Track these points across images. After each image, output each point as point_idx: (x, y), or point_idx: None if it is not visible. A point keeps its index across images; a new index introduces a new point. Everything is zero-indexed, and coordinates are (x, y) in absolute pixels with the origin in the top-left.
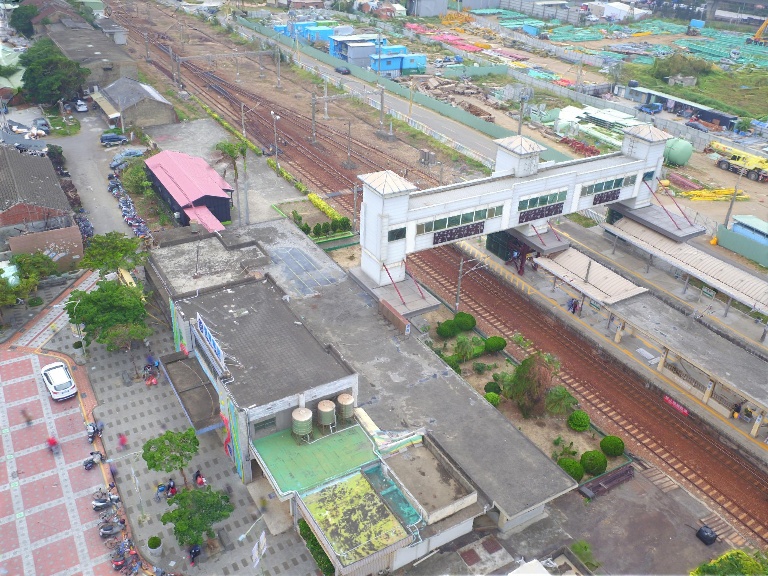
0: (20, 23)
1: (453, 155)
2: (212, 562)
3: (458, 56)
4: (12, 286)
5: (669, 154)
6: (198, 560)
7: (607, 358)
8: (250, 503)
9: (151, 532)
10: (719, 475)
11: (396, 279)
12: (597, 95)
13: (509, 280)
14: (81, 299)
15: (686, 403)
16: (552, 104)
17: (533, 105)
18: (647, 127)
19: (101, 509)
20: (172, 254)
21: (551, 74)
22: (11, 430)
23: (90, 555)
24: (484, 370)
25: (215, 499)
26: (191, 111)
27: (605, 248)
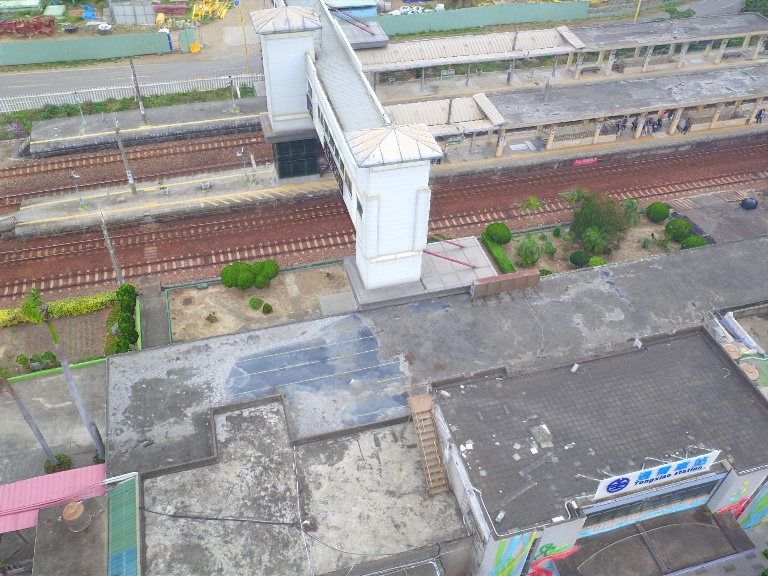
0: None
1: None
2: None
3: None
4: None
5: None
6: None
7: (509, 173)
8: None
9: None
10: (671, 175)
11: None
12: None
13: None
14: None
15: (595, 153)
16: None
17: None
18: None
19: None
20: (189, 571)
21: None
22: None
23: None
24: None
25: None
26: None
27: None
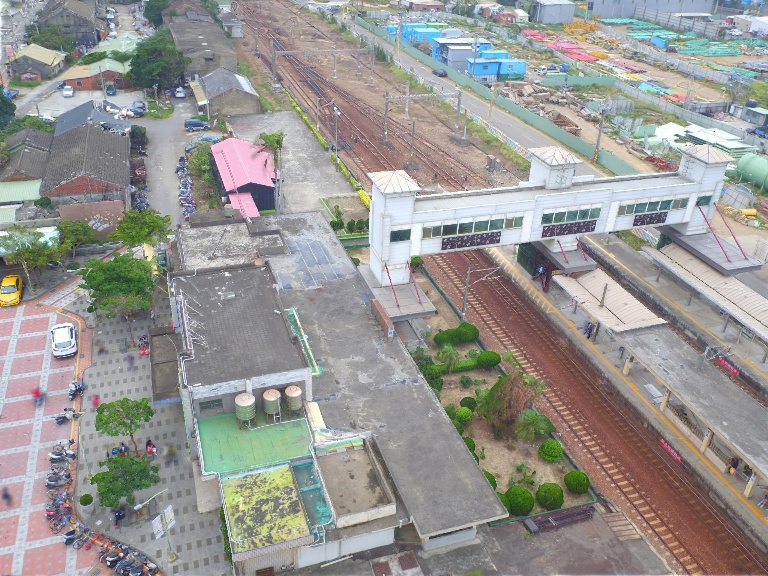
0: (152, 14)
1: (522, 164)
2: (134, 528)
3: (565, 64)
4: (47, 249)
5: (765, 181)
6: (122, 523)
7: (611, 390)
8: (189, 479)
9: (91, 490)
10: (693, 533)
11: (400, 281)
12: (708, 113)
13: (531, 296)
14: (96, 267)
15: (680, 449)
16: (652, 120)
17: (628, 119)
18: (706, 147)
19: (56, 461)
20: (198, 235)
21: (665, 88)
22: (10, 378)
23: (32, 502)
24: (471, 384)
25: (138, 467)
26: (278, 103)
27: (650, 274)
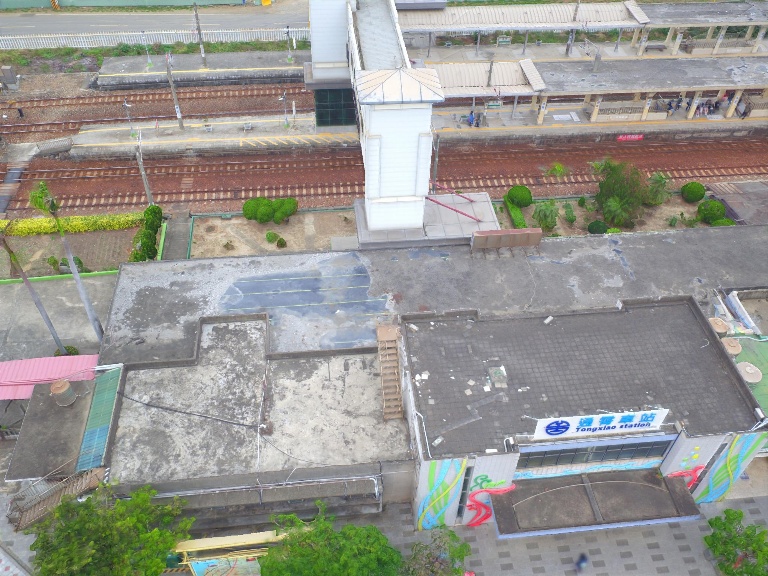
0: None
1: (12, 57)
2: None
3: None
4: None
5: None
6: None
7: (547, 142)
8: (756, 502)
9: None
10: (719, 158)
11: None
12: None
13: None
14: None
15: (641, 129)
16: None
17: None
18: None
19: None
20: (150, 452)
21: None
22: None
23: None
24: None
25: None
26: None
27: None
